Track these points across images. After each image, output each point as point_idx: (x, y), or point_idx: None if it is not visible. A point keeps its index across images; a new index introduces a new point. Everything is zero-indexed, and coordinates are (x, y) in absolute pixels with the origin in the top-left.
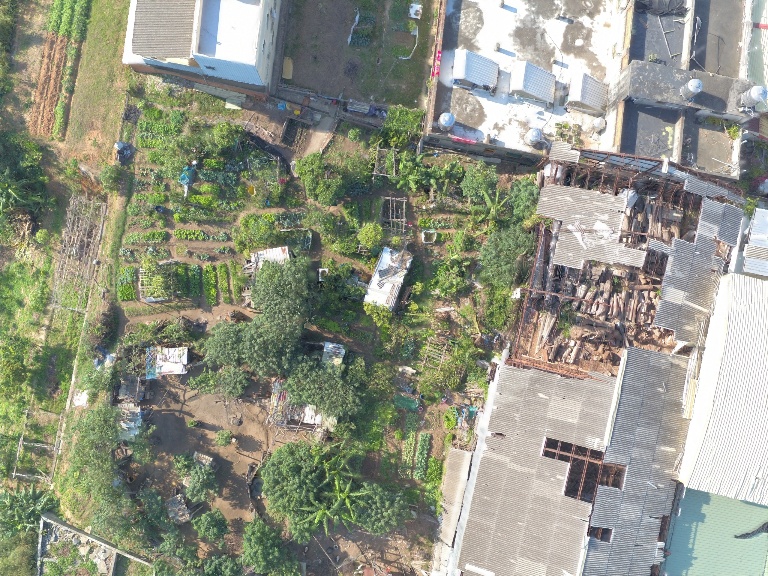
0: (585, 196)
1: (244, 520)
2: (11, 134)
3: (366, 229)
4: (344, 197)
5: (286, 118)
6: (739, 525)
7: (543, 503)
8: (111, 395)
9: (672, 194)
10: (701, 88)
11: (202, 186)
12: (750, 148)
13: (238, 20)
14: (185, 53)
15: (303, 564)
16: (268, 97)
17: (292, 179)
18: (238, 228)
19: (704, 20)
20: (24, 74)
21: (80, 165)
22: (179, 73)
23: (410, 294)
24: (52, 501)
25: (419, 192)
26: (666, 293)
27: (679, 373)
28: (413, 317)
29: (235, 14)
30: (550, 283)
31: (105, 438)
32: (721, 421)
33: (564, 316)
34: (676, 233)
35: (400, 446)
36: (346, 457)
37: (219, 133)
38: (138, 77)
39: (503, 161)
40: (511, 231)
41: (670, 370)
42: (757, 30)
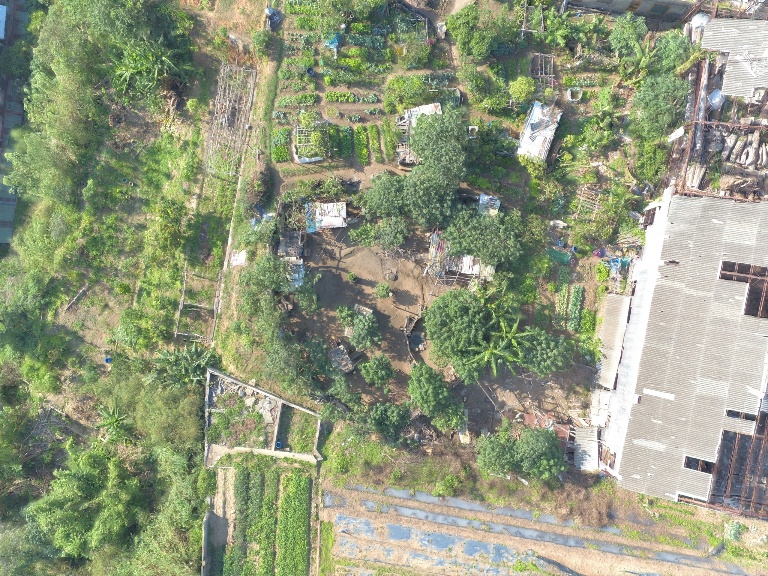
0: (753, 26)
1: (403, 372)
2: (163, 4)
3: (519, 81)
4: (490, 57)
5: None
6: None
7: (722, 323)
8: (273, 250)
9: None
10: None
11: (351, 50)
12: None
13: None
14: None
15: (465, 410)
16: None
17: (438, 41)
18: None
19: None
20: None
21: (230, 33)
22: None
23: (560, 149)
24: (214, 358)
25: (563, 51)
26: None
27: None
28: (567, 167)
29: None
30: (701, 132)
31: (276, 283)
32: None
33: (713, 166)
34: None
35: (553, 298)
36: (508, 301)
37: None
38: None
39: (646, 19)
40: None
41: None
42: None
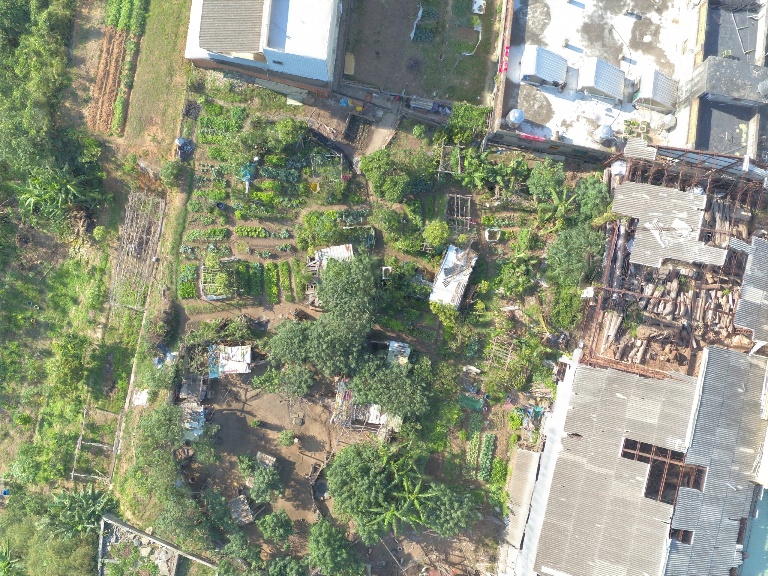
0: (663, 194)
1: (307, 521)
2: (69, 129)
3: (432, 227)
4: (407, 194)
5: (348, 114)
6: None
7: (622, 505)
8: (173, 394)
9: (740, 192)
10: None
11: (263, 183)
12: None
13: (308, 14)
14: (254, 47)
15: (368, 566)
16: (330, 93)
17: (354, 176)
18: (300, 225)
19: None
20: (82, 69)
21: (139, 161)
22: (241, 68)
23: (475, 293)
24: (111, 501)
25: (482, 190)
26: (746, 292)
27: (758, 373)
28: (480, 316)
29: (305, 8)
30: (617, 282)
31: (171, 438)
32: None
33: (630, 315)
34: (744, 232)
35: (464, 447)
36: (413, 458)
37: (284, 129)
38: (198, 72)
39: (567, 158)
40: (580, 229)
41: (749, 370)
42: None
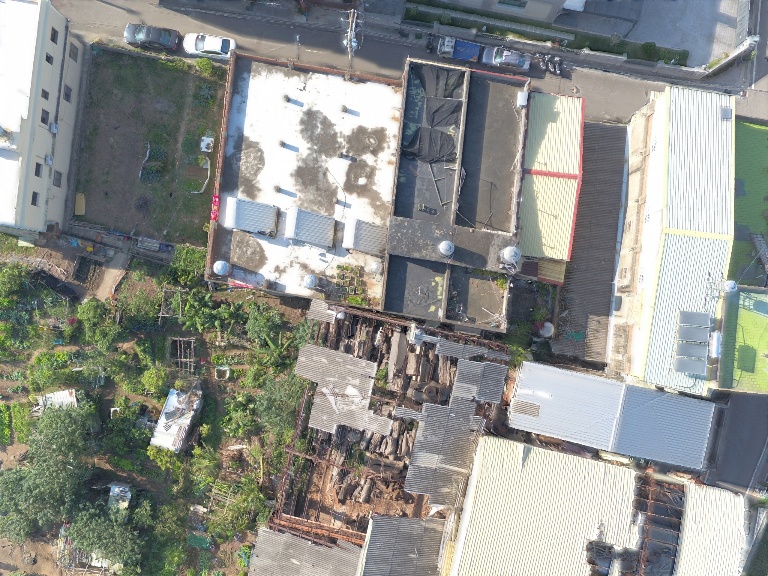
0: (339, 359)
1: None
2: None
3: (148, 374)
4: (137, 334)
5: (78, 256)
6: None
7: None
8: None
9: None
10: (452, 250)
11: None
12: (537, 287)
13: (0, 177)
14: None
15: None
16: (59, 235)
17: None
18: None
19: (476, 166)
20: None
21: None
22: None
23: (200, 433)
24: None
25: (213, 328)
26: (417, 458)
27: (434, 536)
28: (197, 461)
29: None
30: None
31: None
32: None
33: (354, 455)
34: None
35: None
36: None
37: (0, 280)
38: None
39: None
40: (291, 376)
41: (423, 534)
42: (529, 176)
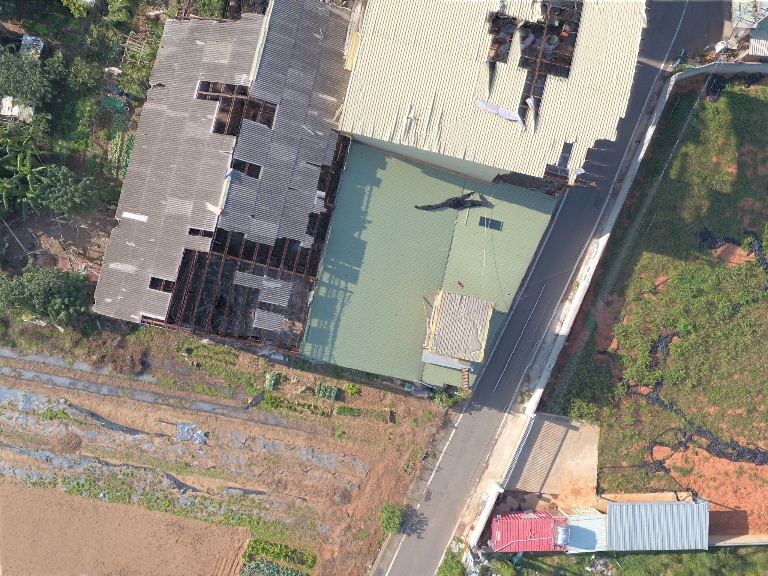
0: None
1: None
2: None
3: None
4: None
5: None
6: (420, 196)
7: (193, 143)
8: None
9: None
10: None
11: None
12: None
13: None
14: None
15: None
16: None
17: None
18: None
19: None
20: None
21: None
22: None
23: None
24: None
25: None
26: None
27: (340, 23)
28: (110, 8)
29: None
30: None
31: None
32: (369, 58)
33: None
34: None
35: (106, 146)
36: (34, 139)
37: None
38: None
39: None
40: None
41: (329, 18)
42: None
